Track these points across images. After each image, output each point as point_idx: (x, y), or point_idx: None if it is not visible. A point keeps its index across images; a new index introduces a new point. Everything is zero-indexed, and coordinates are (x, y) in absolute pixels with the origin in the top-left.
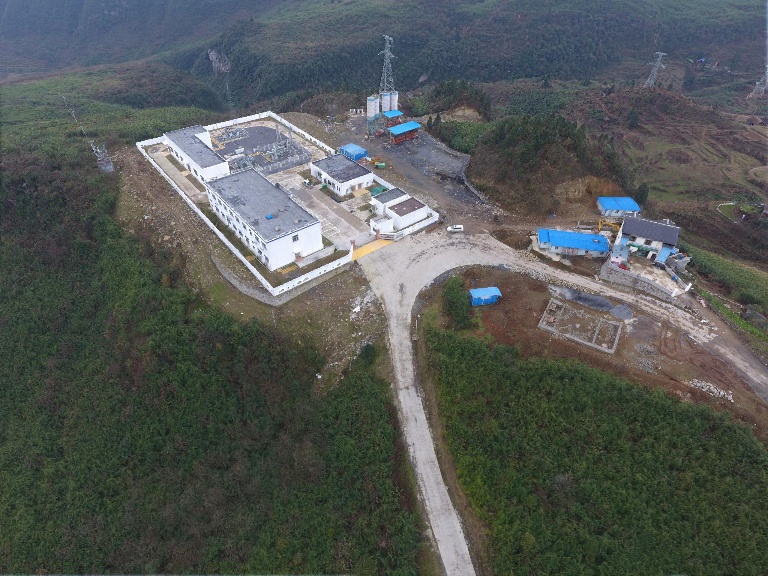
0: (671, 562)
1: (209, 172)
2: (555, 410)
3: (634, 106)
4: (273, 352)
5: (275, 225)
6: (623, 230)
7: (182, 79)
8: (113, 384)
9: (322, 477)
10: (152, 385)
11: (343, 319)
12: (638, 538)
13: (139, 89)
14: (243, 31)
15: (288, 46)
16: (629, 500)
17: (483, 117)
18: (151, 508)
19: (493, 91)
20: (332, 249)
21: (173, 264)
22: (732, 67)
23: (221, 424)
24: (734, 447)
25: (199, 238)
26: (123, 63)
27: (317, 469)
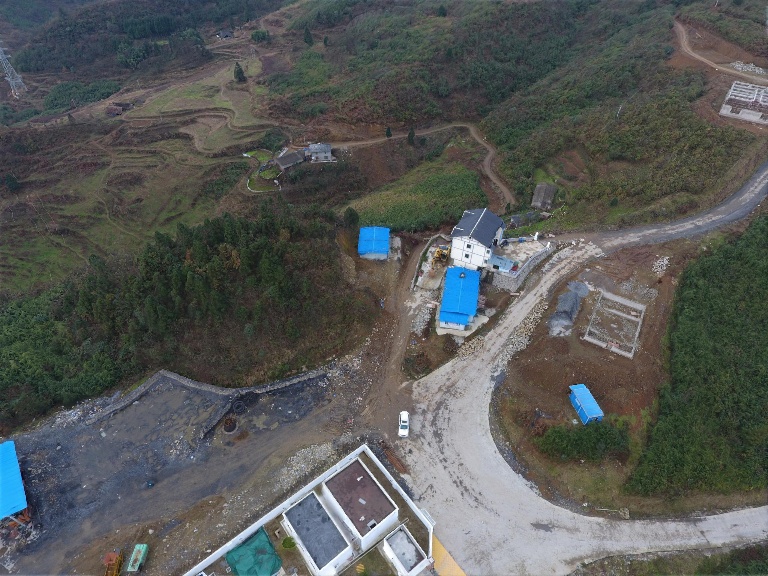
0: None
1: None
2: None
3: None
4: None
5: None
6: (487, 246)
7: None
8: None
9: None
10: None
11: None
12: None
13: None
14: None
15: None
16: None
17: None
18: None
19: None
20: None
21: None
22: None
23: None
24: None
25: None
26: None
27: None
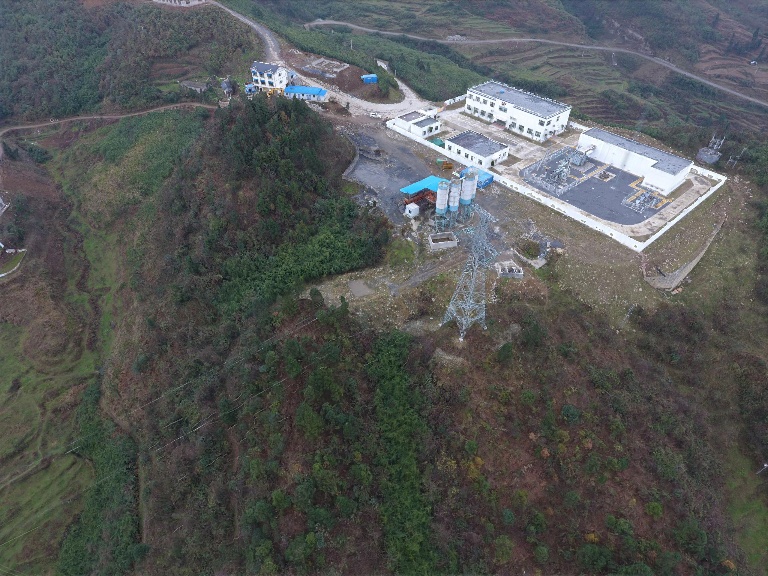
0: None
1: None
2: None
3: None
4: None
5: (495, 89)
6: (285, 67)
7: None
8: None
9: None
10: None
11: None
12: None
13: None
14: None
15: None
16: None
17: None
18: None
19: None
20: (458, 111)
21: None
22: None
23: None
24: None
25: None
26: None
27: None
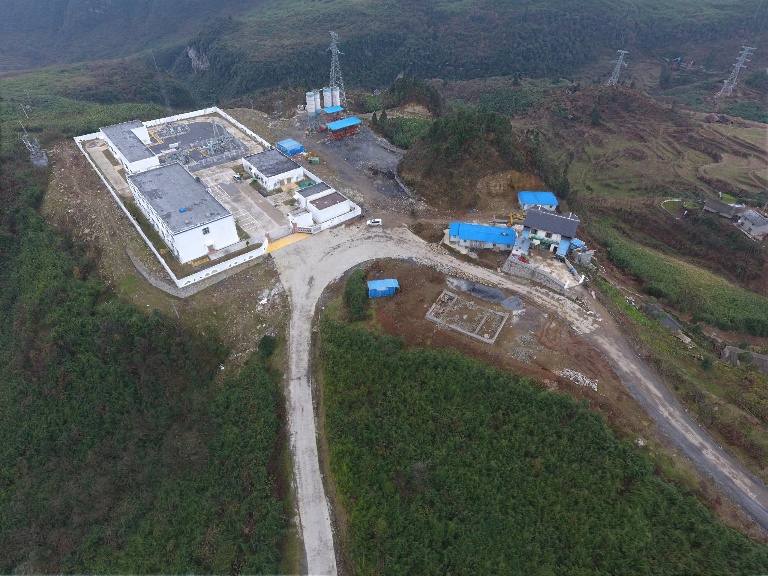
0: (513, 546)
1: (137, 166)
2: (426, 399)
3: (597, 104)
4: (173, 343)
5: (186, 218)
6: (524, 223)
7: (154, 76)
8: (18, 375)
9: (205, 466)
10: (50, 375)
11: (249, 311)
12: (486, 523)
13: (109, 86)
14: (221, 29)
15: (264, 44)
16: (480, 486)
17: (433, 114)
18: (43, 497)
19: (465, 89)
20: None
21: (86, 257)
22: (707, 66)
23: (118, 414)
24: (585, 434)
25: (117, 231)
26: None
27: (199, 458)
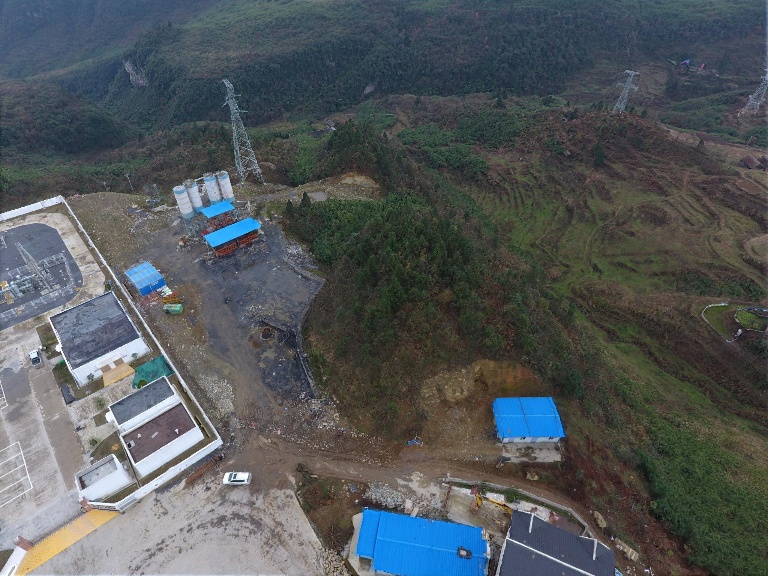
0: None
1: None
2: None
3: (600, 138)
4: None
5: None
6: None
7: (67, 104)
8: None
9: None
10: None
11: None
12: None
13: (7, 121)
14: (160, 38)
15: (207, 57)
16: None
17: (381, 185)
18: None
19: (441, 110)
20: None
21: None
22: (720, 70)
23: None
24: None
25: None
26: (7, 83)
27: None
